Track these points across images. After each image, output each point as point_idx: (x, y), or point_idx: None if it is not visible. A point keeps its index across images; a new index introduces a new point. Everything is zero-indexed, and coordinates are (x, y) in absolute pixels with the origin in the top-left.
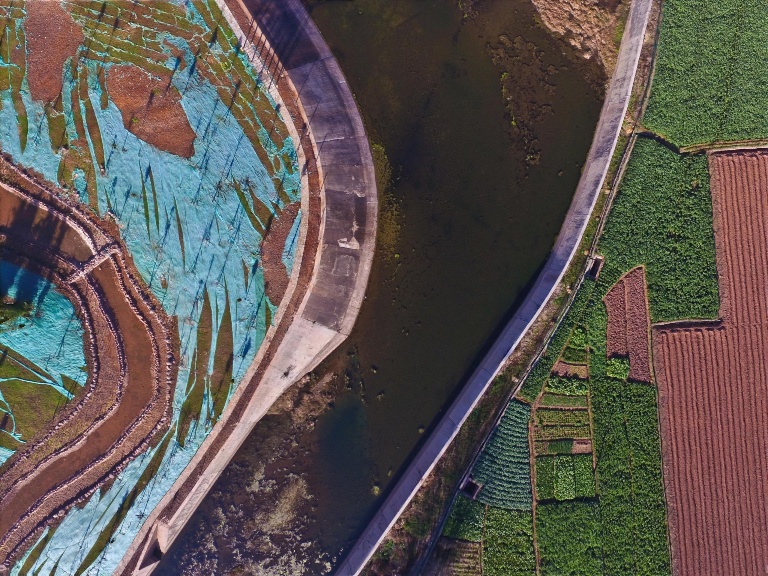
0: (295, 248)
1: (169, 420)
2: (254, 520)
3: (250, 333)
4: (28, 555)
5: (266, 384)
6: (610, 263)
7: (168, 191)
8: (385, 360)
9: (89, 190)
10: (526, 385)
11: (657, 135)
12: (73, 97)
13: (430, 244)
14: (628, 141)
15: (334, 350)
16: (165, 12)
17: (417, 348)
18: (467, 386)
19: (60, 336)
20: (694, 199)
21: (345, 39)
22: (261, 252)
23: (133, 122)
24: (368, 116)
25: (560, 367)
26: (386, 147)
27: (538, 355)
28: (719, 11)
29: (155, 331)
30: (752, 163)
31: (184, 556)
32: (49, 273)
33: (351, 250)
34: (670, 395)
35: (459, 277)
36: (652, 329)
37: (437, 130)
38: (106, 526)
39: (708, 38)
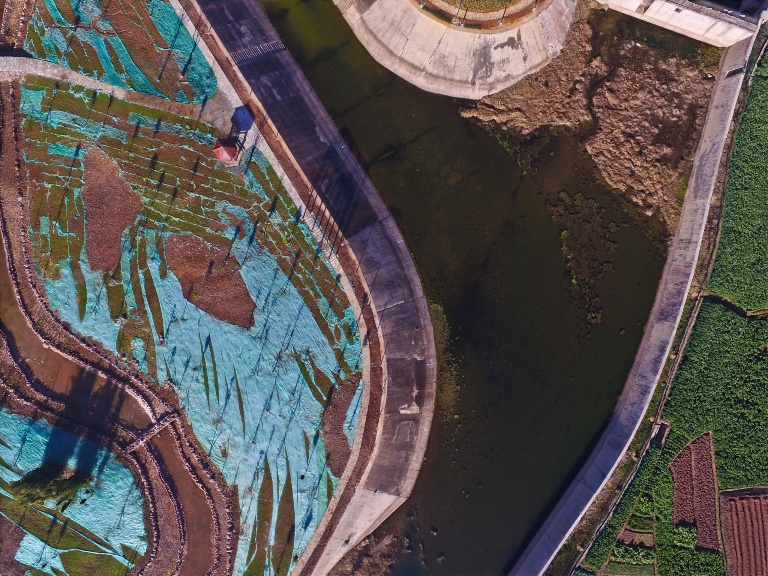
0: (357, 419)
1: None
2: None
3: (312, 504)
4: None
5: (328, 555)
6: (677, 431)
7: (228, 361)
8: (445, 521)
9: (148, 359)
10: (592, 554)
11: (724, 298)
12: (132, 266)
13: (490, 404)
14: (694, 304)
15: (393, 512)
16: (224, 181)
17: (477, 509)
18: (529, 550)
19: (120, 506)
20: (763, 364)
21: (402, 197)
22: (322, 423)
23: (192, 291)
24: (426, 275)
25: (626, 535)
26: (445, 306)
27: (603, 522)
28: None
29: (215, 499)
30: None
31: None
32: (109, 442)
33: (411, 415)
34: (739, 564)
35: (520, 437)
36: (720, 495)
37: (496, 288)
38: None
39: None
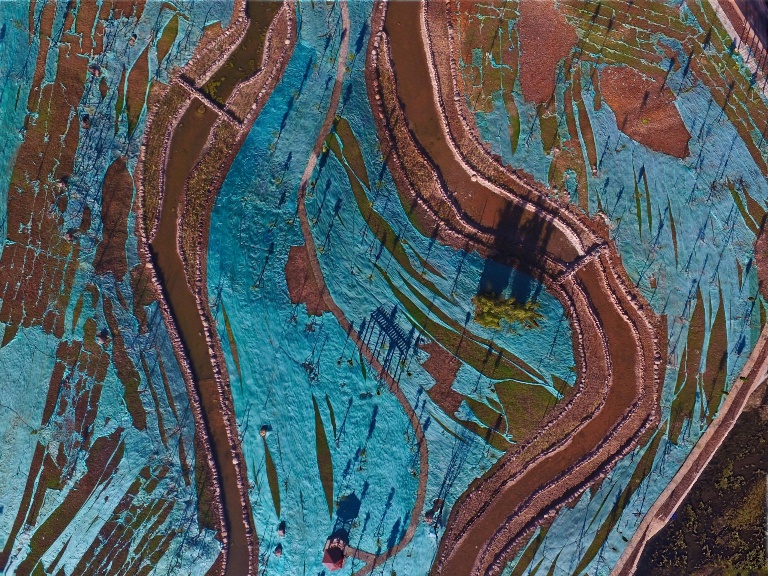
0: None
1: (658, 419)
2: (723, 516)
3: (744, 331)
4: (521, 555)
5: (758, 381)
6: None
7: (662, 191)
8: None
9: (579, 191)
10: None
11: None
12: (566, 98)
13: None
14: None
15: None
16: (659, 13)
17: None
18: None
19: (552, 337)
20: None
21: None
22: (755, 251)
23: (626, 123)
24: None
25: None
26: None
27: None
28: None
29: (640, 330)
30: None
31: (654, 553)
32: (539, 274)
33: None
34: None
35: None
36: None
37: None
38: (602, 525)
39: None
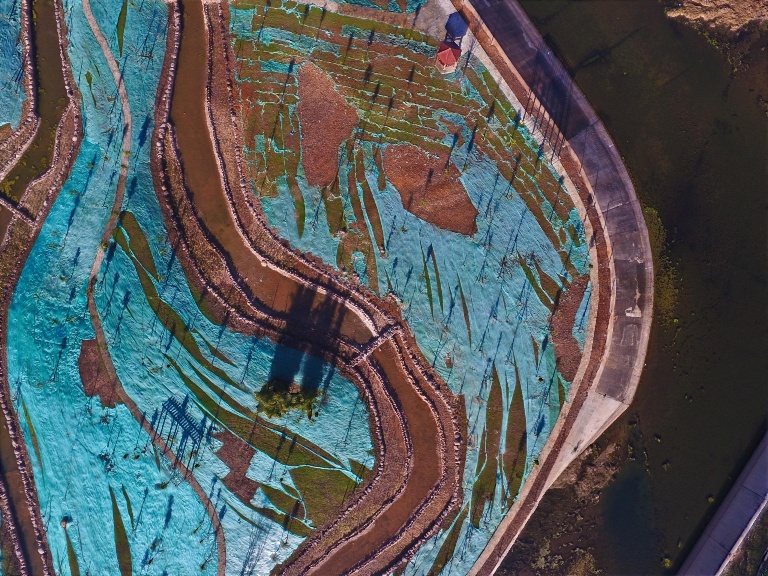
0: (586, 322)
1: (460, 501)
2: None
3: (543, 410)
4: None
5: (561, 461)
6: None
7: (451, 270)
8: (668, 428)
9: (369, 272)
10: None
11: None
12: (350, 180)
13: (709, 306)
14: None
15: (615, 420)
16: (440, 89)
17: (701, 414)
18: (759, 452)
19: (347, 420)
20: None
21: (610, 101)
22: (550, 327)
23: (412, 202)
24: (638, 179)
25: None
26: (659, 209)
27: None
28: None
29: (439, 411)
30: None
31: None
32: (332, 357)
33: (635, 318)
34: None
35: (741, 339)
36: None
37: (711, 189)
38: None
39: None
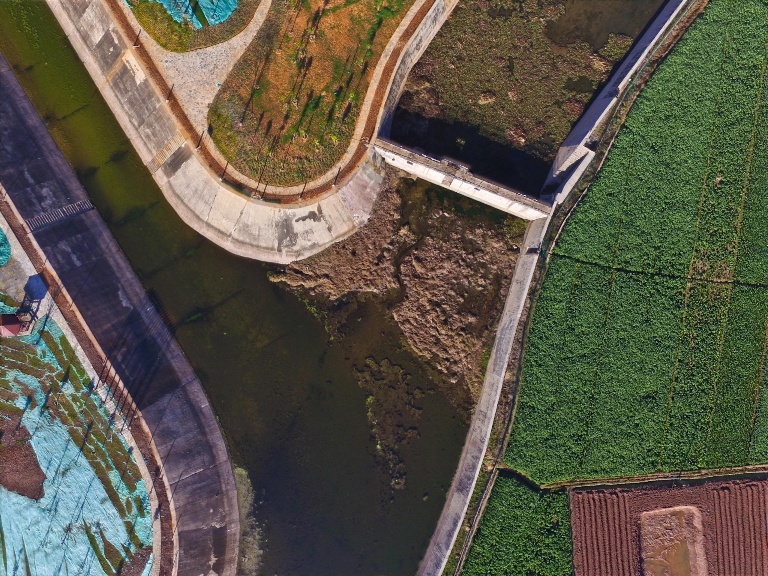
0: None
1: None
2: None
3: None
4: None
5: None
6: None
7: (16, 532)
8: None
9: None
10: None
11: (518, 472)
12: None
13: (293, 568)
14: (489, 477)
15: None
16: (16, 350)
17: None
18: None
19: None
20: (553, 538)
21: (209, 360)
22: None
23: None
24: (231, 438)
25: None
26: (249, 470)
27: None
28: (580, 350)
29: None
30: (612, 501)
31: None
32: None
33: None
34: None
35: None
36: None
37: (302, 452)
38: None
39: (569, 378)
